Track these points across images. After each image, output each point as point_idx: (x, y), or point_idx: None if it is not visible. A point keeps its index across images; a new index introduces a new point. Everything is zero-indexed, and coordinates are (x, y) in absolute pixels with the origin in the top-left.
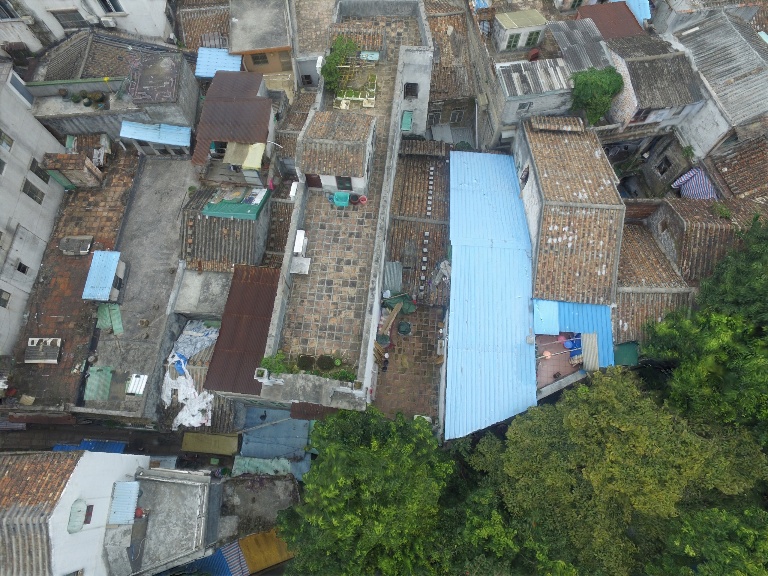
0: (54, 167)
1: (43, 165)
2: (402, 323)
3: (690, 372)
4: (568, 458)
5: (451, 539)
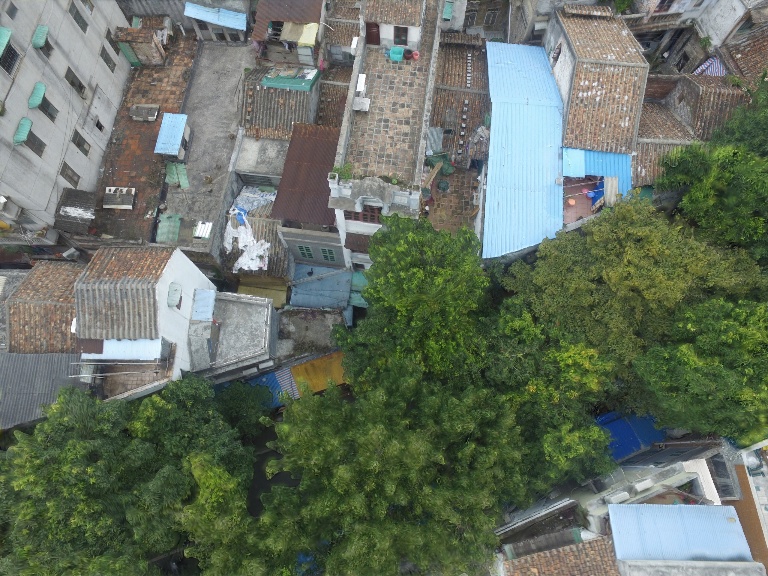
0: (125, 39)
1: (115, 37)
2: (441, 181)
3: (699, 194)
4: (590, 268)
5: (486, 335)
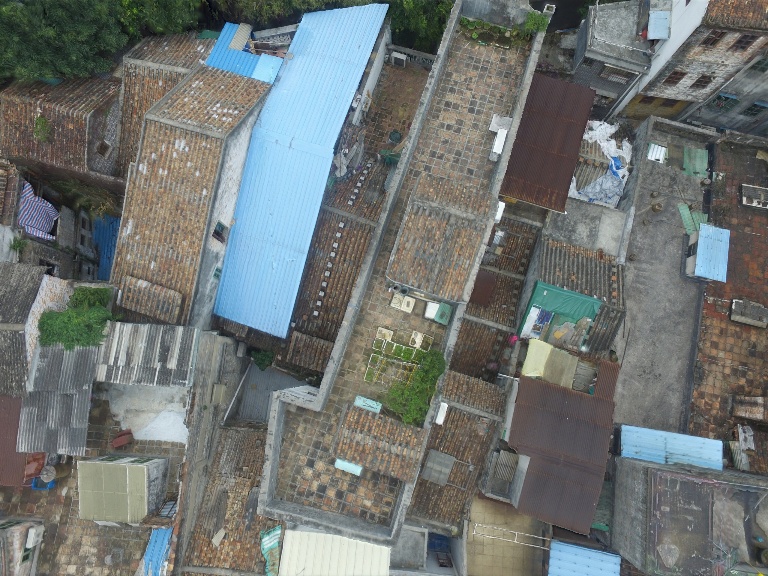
0: None
1: None
2: (396, 141)
3: None
4: None
5: None
